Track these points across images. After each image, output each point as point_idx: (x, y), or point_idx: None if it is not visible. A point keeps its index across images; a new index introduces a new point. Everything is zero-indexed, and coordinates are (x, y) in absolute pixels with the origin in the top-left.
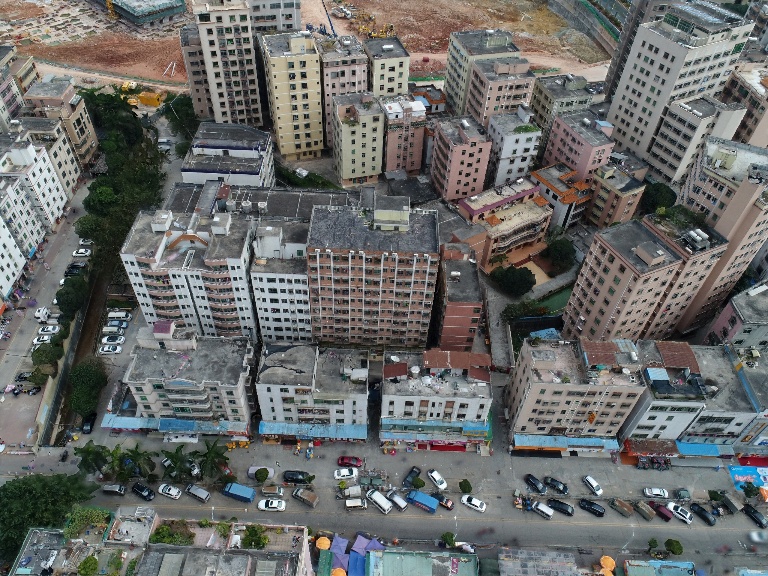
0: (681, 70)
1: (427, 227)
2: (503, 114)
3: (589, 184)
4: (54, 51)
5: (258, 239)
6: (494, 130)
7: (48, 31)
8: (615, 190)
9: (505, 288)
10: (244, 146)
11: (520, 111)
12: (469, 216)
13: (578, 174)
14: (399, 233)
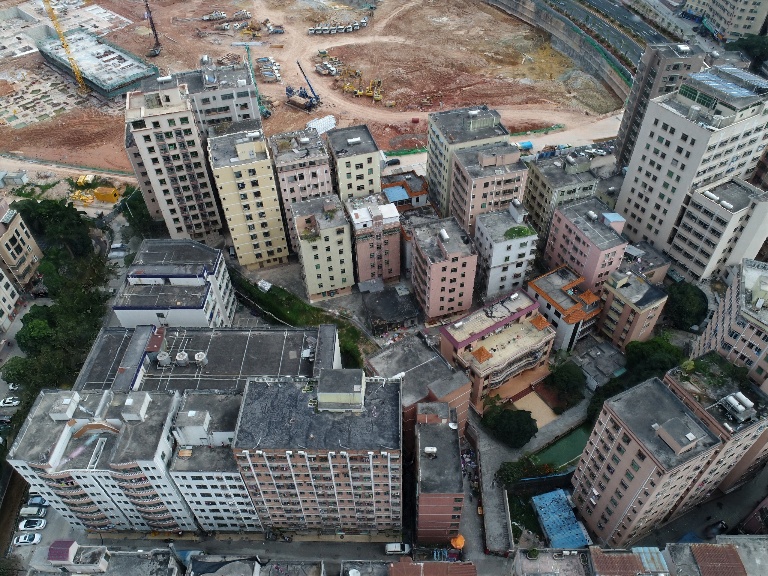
0: (704, 155)
1: (388, 404)
2: (492, 213)
3: (600, 287)
4: (19, 135)
5: (178, 429)
6: (481, 233)
7: (15, 112)
8: (630, 304)
9: (500, 438)
10: (187, 273)
11: (512, 209)
12: (453, 348)
13: (586, 277)
14: (352, 416)
